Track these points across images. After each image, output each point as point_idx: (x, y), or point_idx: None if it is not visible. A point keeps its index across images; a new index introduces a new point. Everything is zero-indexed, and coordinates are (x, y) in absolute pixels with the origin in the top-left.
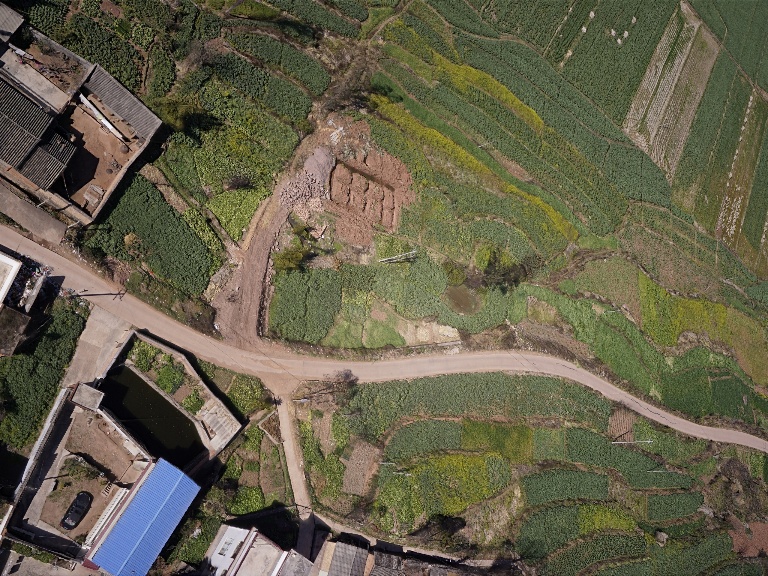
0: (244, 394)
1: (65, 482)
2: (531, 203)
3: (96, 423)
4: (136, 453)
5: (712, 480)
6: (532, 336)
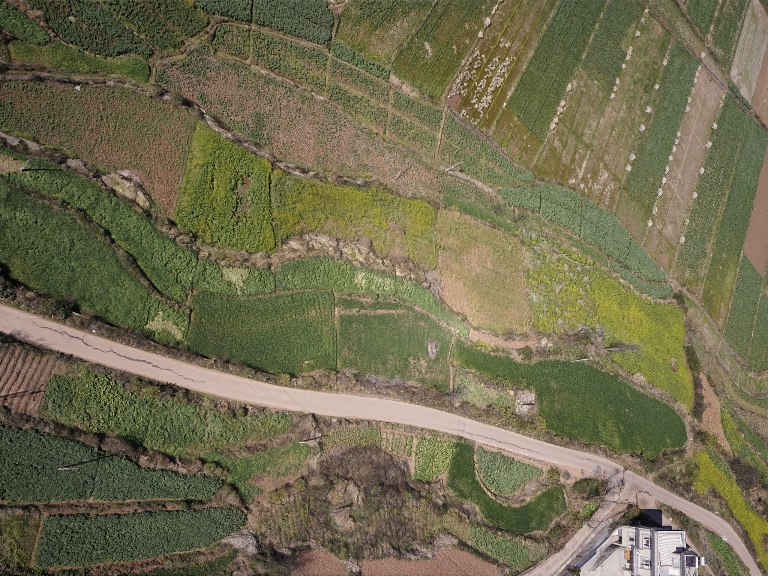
0: None
1: None
2: None
3: None
4: None
5: (287, 484)
6: None
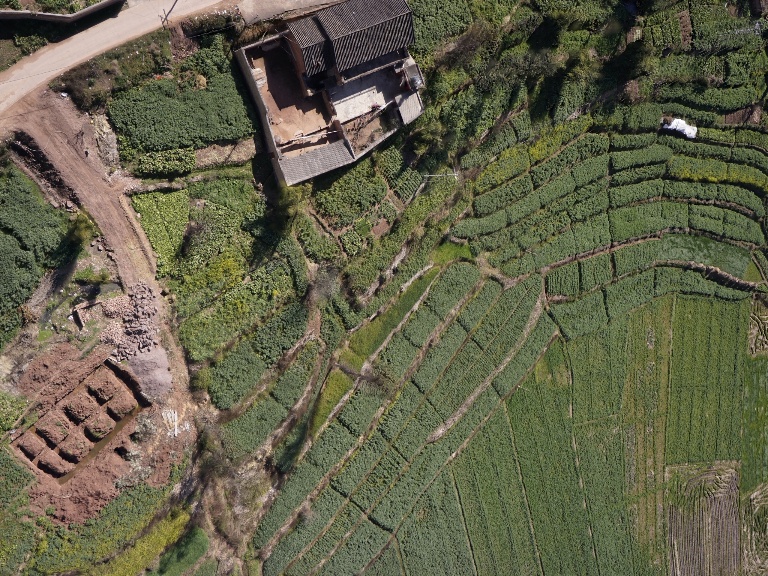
0: None
1: None
2: None
3: None
4: None
5: None
6: None
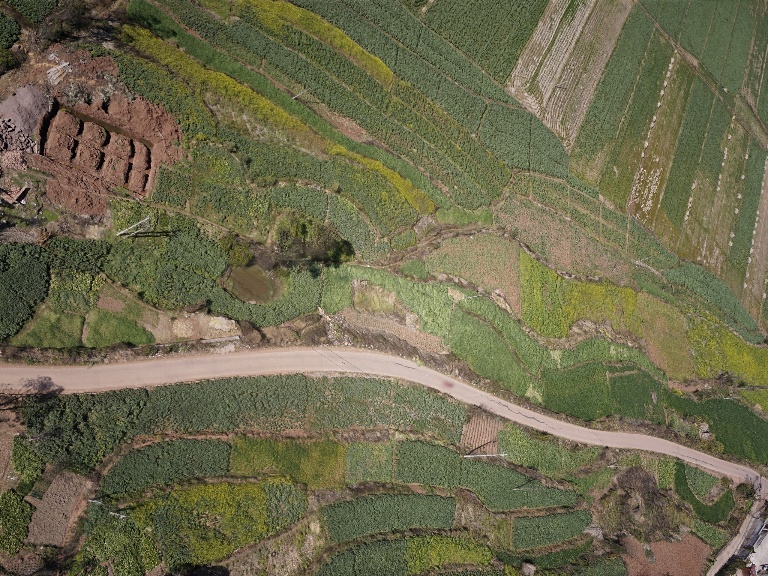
0: None
1: None
2: (366, 167)
3: None
4: None
5: (605, 494)
6: (357, 328)
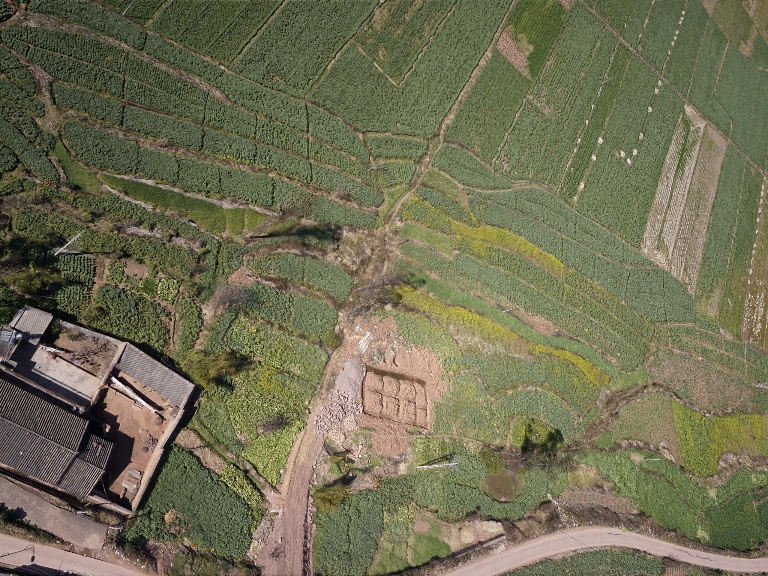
0: None
1: None
2: (560, 359)
3: None
4: None
5: None
6: (575, 505)
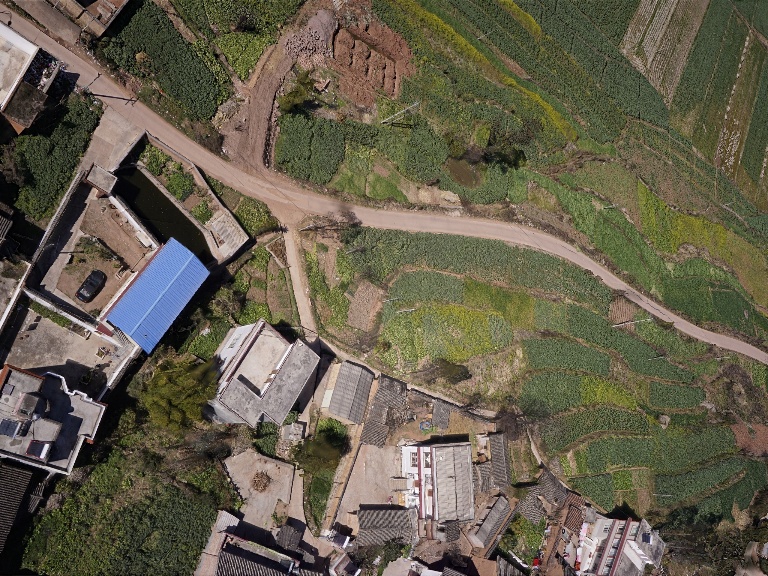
0: (251, 215)
1: (80, 258)
2: (530, 98)
3: (109, 213)
4: (148, 244)
5: (714, 380)
6: (532, 218)
